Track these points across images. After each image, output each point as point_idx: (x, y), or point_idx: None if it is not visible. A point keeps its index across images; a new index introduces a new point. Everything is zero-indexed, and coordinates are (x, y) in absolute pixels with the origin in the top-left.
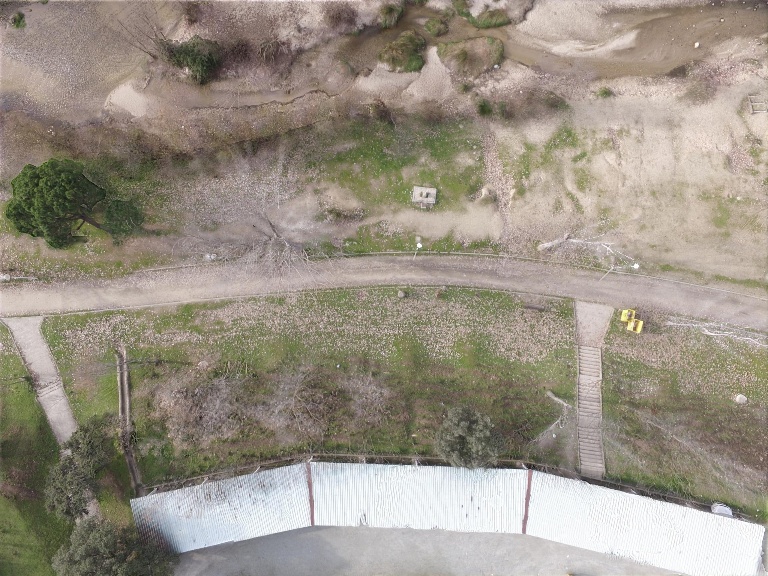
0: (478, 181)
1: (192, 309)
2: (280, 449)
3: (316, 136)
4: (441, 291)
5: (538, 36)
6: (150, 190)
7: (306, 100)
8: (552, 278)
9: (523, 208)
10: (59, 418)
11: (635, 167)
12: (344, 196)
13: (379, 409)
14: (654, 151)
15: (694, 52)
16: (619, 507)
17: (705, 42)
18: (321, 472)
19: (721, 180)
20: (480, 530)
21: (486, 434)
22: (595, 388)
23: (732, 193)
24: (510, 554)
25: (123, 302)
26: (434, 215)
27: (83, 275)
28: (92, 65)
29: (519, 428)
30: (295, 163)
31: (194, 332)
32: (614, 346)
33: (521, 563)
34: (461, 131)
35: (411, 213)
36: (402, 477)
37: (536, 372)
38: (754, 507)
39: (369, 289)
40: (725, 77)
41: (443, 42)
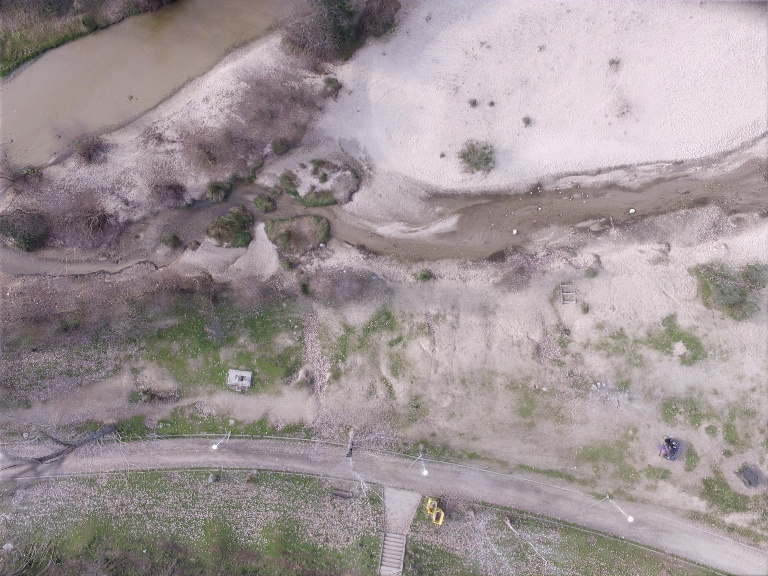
0: (297, 362)
1: (1, 489)
2: None
3: (139, 310)
4: (252, 475)
5: (363, 217)
6: None
7: (134, 271)
8: (362, 464)
9: (337, 393)
10: None
11: (448, 354)
12: (160, 376)
13: None
14: (467, 338)
15: (513, 238)
16: None
17: (523, 229)
18: None
19: (529, 370)
20: None
21: None
22: None
23: (538, 384)
24: None
25: None
26: (249, 397)
27: None
28: None
29: None
30: (116, 339)
31: (1, 513)
32: (419, 534)
33: None
34: (284, 310)
35: (226, 395)
36: None
37: (341, 560)
38: None
39: (181, 471)
40: (541, 263)
41: (271, 219)
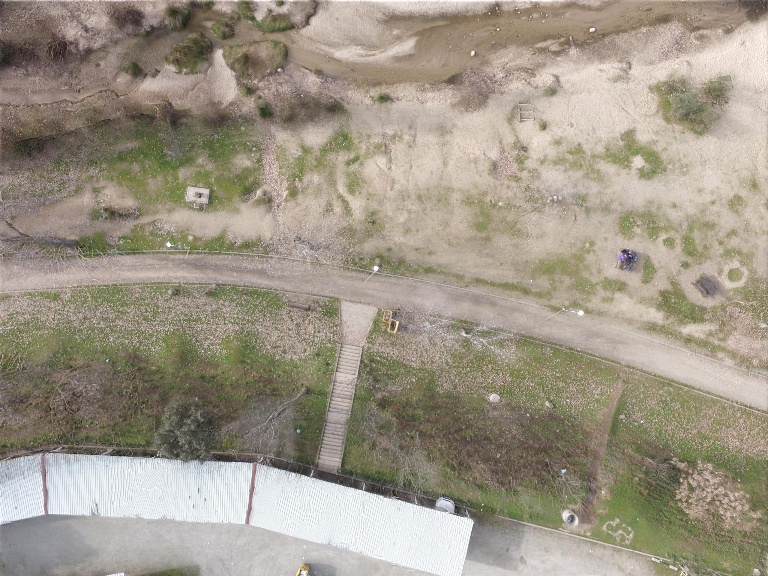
0: (255, 182)
1: None
2: (29, 440)
3: (100, 135)
4: (211, 289)
5: (321, 41)
6: None
7: (95, 99)
8: (319, 278)
9: (294, 210)
10: None
11: (404, 172)
12: (121, 195)
13: (135, 403)
14: (424, 156)
15: (471, 60)
16: (314, 499)
17: (482, 50)
18: (54, 463)
19: (485, 186)
20: (214, 520)
21: (191, 428)
22: (350, 385)
23: (494, 199)
24: (250, 544)
25: None
26: (208, 215)
27: None
28: None
29: None
30: (77, 161)
31: None
32: (376, 345)
33: (260, 553)
34: (242, 133)
35: (185, 213)
36: None
37: (298, 369)
38: (479, 502)
39: (142, 286)
40: (500, 85)
41: (229, 45)
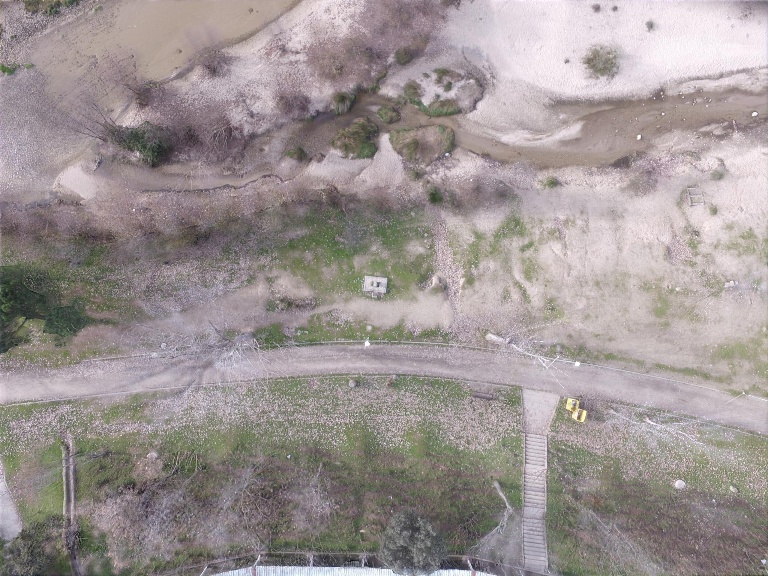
0: (429, 269)
1: (141, 399)
2: (227, 549)
3: (269, 222)
4: (392, 380)
5: (488, 125)
6: (99, 276)
7: (259, 184)
8: (500, 367)
9: (472, 297)
10: (1, 514)
11: (580, 257)
12: (296, 285)
13: None
14: (598, 241)
15: (637, 144)
16: None
17: (647, 134)
18: None
19: (661, 271)
20: None
21: (427, 545)
22: (540, 477)
23: (671, 284)
24: None
25: (70, 392)
26: (385, 304)
27: (28, 365)
28: (40, 146)
29: (465, 522)
30: (247, 250)
31: (143, 423)
32: (559, 433)
33: None
34: (413, 218)
35: (362, 302)
36: (351, 570)
37: (484, 461)
38: None
39: (320, 378)
40: (666, 168)
41: (395, 129)
